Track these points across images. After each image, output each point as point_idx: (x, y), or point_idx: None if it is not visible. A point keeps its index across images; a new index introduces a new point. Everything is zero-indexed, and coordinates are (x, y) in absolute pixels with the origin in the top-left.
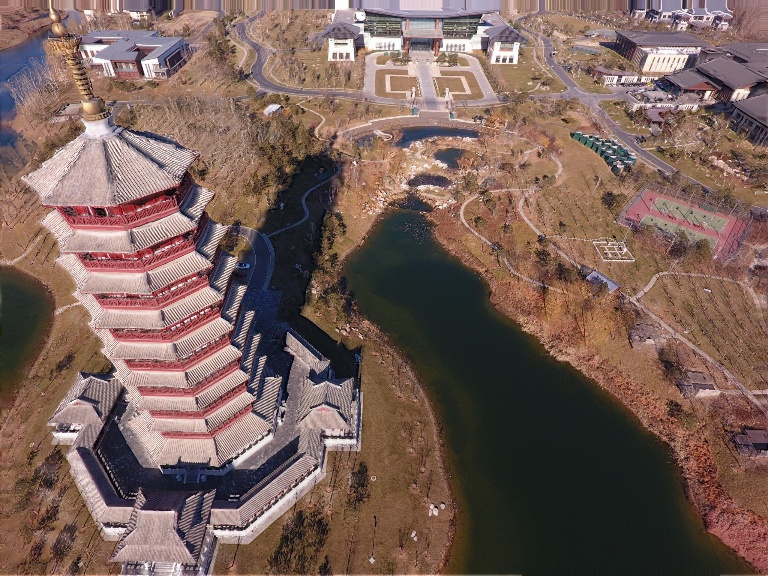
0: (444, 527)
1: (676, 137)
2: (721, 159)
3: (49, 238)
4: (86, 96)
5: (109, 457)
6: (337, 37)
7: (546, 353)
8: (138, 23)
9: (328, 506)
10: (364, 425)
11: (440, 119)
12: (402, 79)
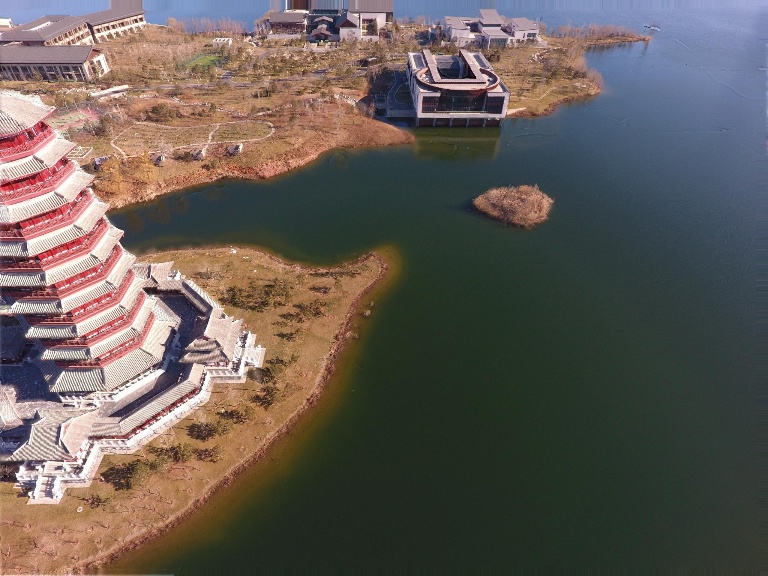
0: (243, 250)
1: None
2: None
3: None
4: None
5: None
6: None
7: (144, 203)
8: None
9: None
10: None
11: None
12: None
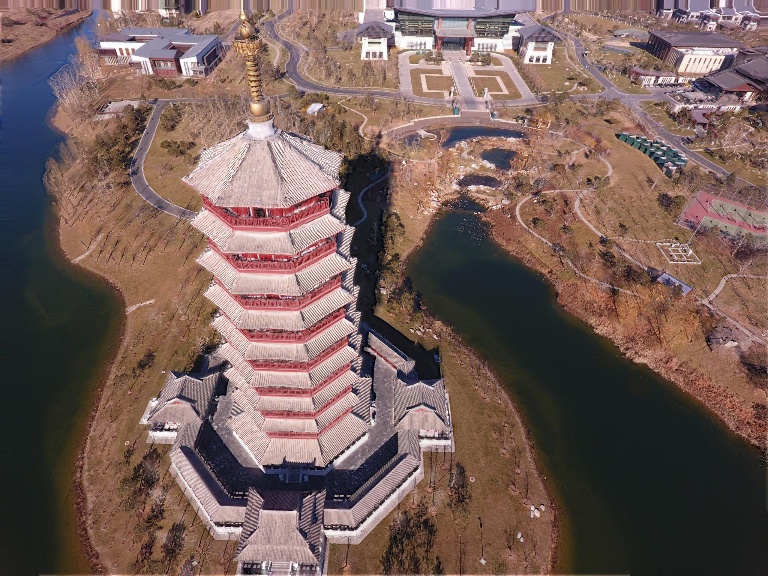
0: (547, 529)
1: (726, 139)
2: None
3: (111, 236)
4: (256, 97)
5: (208, 456)
6: (371, 36)
7: (621, 355)
8: (168, 21)
9: (434, 507)
10: (454, 426)
11: (482, 119)
12: (437, 78)
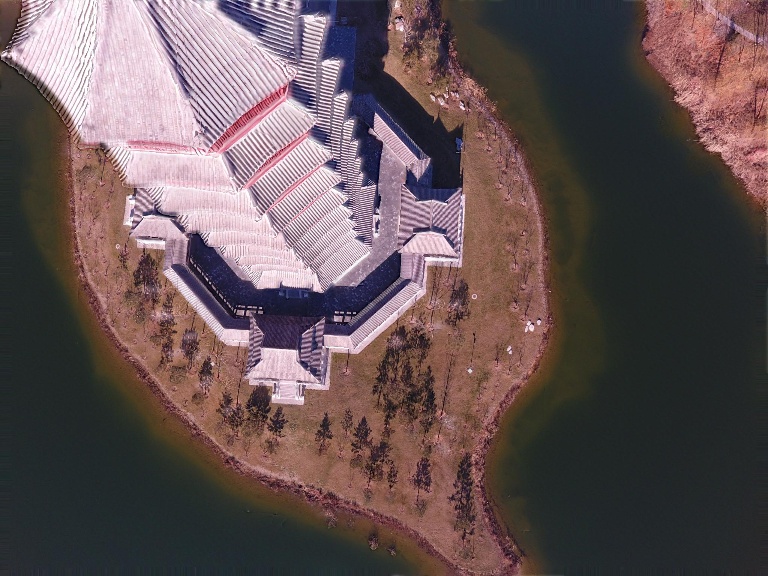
0: (537, 341)
1: None
2: None
3: None
4: None
5: (204, 267)
6: None
7: (695, 137)
8: None
9: None
10: (466, 237)
11: None
12: None
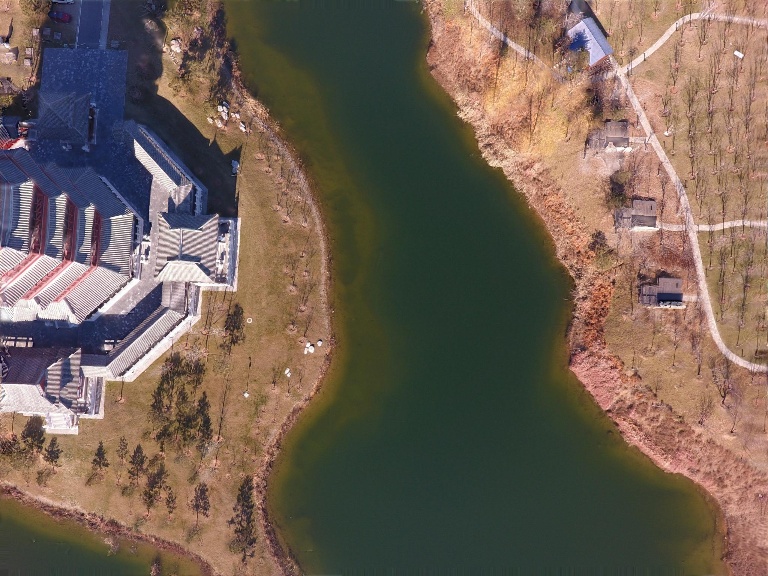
0: (318, 362)
1: None
2: None
3: None
4: None
5: None
6: None
7: (479, 153)
8: None
9: None
10: (241, 261)
11: None
12: None
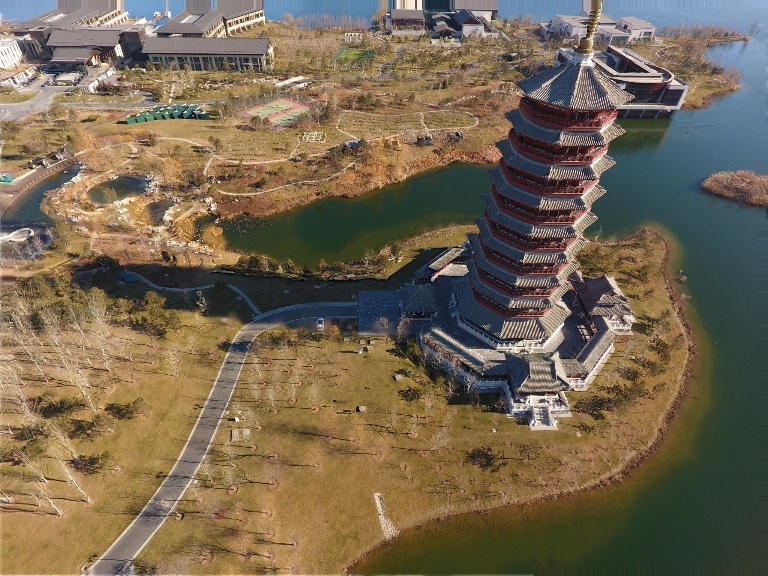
0: None
1: None
2: (205, 83)
3: None
4: None
5: None
6: None
7: (398, 184)
8: None
9: None
10: None
11: (2, 190)
12: None
